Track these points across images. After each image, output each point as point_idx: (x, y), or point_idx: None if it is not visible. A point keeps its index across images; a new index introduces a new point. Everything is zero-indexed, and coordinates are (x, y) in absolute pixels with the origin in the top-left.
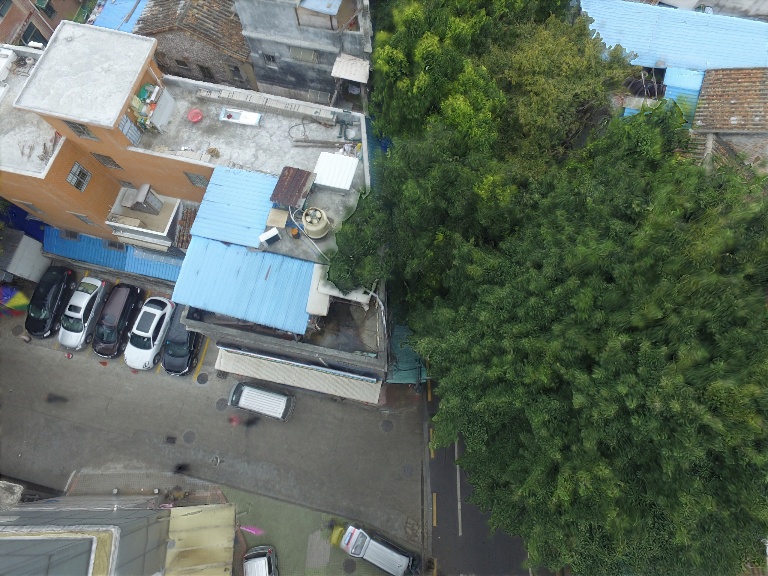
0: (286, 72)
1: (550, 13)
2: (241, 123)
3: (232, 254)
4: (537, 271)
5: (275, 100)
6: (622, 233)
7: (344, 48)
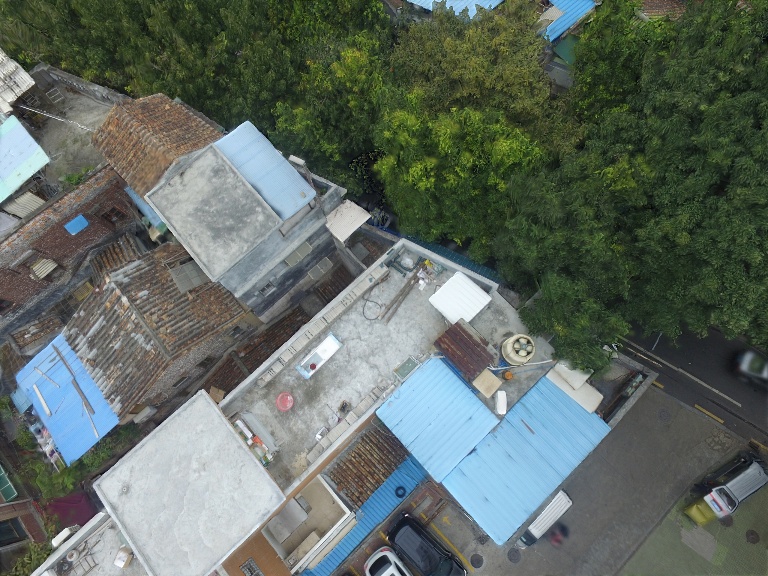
0: (283, 283)
1: (409, 27)
2: (327, 359)
3: (487, 452)
4: (746, 188)
5: (330, 311)
6: (767, 102)
7: (325, 212)
